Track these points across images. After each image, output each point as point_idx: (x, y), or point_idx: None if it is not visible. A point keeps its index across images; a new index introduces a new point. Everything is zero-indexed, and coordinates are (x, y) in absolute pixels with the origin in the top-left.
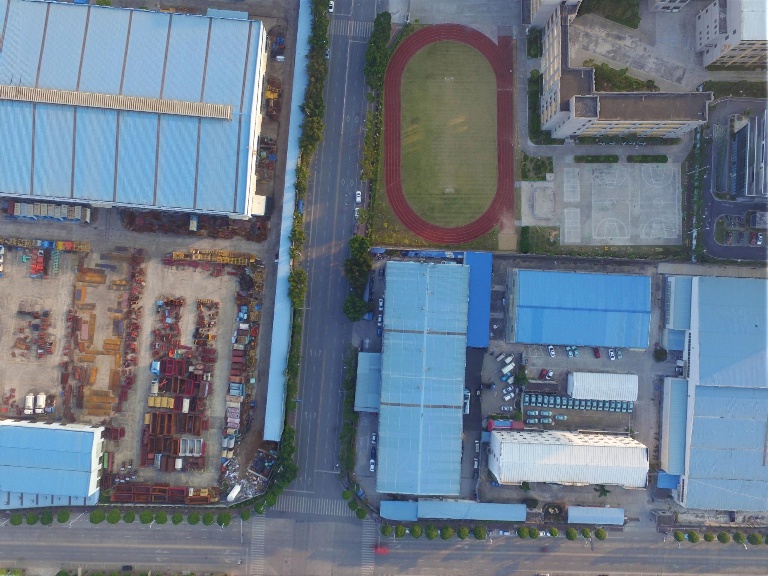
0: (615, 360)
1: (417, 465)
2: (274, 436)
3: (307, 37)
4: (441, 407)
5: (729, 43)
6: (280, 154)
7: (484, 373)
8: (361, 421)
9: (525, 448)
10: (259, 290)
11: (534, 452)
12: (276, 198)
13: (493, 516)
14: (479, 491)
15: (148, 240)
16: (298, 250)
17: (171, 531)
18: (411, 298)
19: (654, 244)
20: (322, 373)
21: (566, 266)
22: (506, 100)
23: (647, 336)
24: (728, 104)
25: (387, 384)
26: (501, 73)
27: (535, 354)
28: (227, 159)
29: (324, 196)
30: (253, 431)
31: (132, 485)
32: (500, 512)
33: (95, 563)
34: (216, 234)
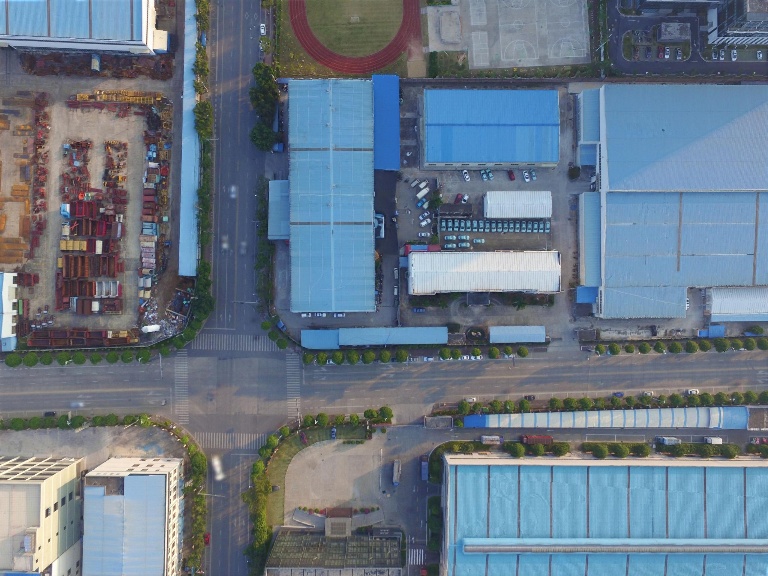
0: (530, 182)
1: (330, 282)
2: (189, 271)
3: None
4: (351, 224)
5: None
6: None
7: (400, 201)
8: (278, 255)
9: (437, 258)
10: (167, 128)
11: (446, 261)
12: (179, 35)
13: (415, 340)
14: (401, 319)
15: (51, 83)
16: None
17: (92, 376)
18: (315, 115)
19: (563, 64)
20: (236, 209)
21: None
22: None
23: (557, 149)
24: None
25: (296, 203)
26: None
27: (450, 180)
28: None
29: (228, 31)
30: (170, 271)
31: (49, 330)
32: (421, 335)
33: (17, 412)
34: (120, 74)
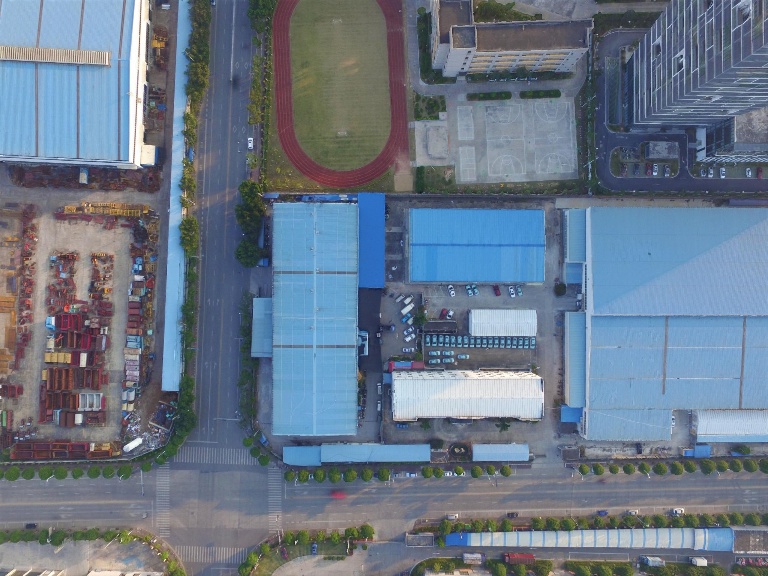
0: (516, 297)
1: (312, 406)
2: (172, 386)
3: None
4: (334, 347)
5: None
6: (170, 103)
7: (384, 315)
8: (262, 369)
9: (419, 384)
10: (153, 241)
11: (428, 387)
12: (167, 148)
13: (397, 457)
14: (384, 434)
15: (39, 195)
16: (190, 198)
17: (74, 487)
18: (299, 239)
19: (550, 179)
20: (221, 322)
21: (463, 205)
22: (396, 41)
23: (543, 270)
24: (619, 36)
25: (279, 326)
26: (390, 13)
27: (435, 294)
28: (108, 106)
29: (216, 144)
30: (153, 383)
31: (32, 442)
32: (404, 453)
33: None
34: (108, 186)
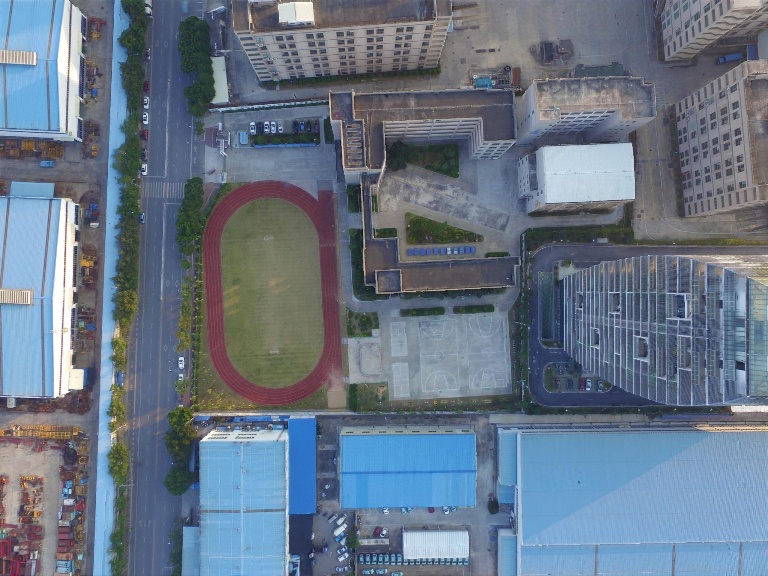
0: (449, 513)
1: None
2: None
3: (116, 207)
4: None
5: (539, 201)
6: (99, 323)
7: (318, 534)
8: None
9: None
10: (83, 463)
11: None
12: (97, 368)
13: None
14: None
15: None
16: (119, 423)
17: None
18: (226, 477)
19: (484, 395)
20: (153, 544)
21: (396, 421)
22: (329, 256)
23: (474, 494)
24: (552, 250)
25: (206, 565)
26: (323, 228)
27: (369, 512)
28: (32, 344)
29: (147, 363)
30: None
31: None
32: None
33: None
34: (36, 409)
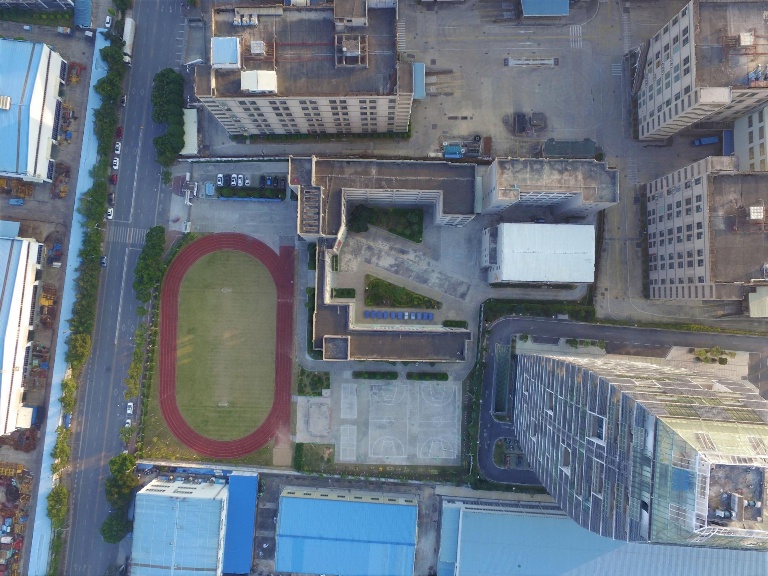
0: None
1: None
2: None
3: (78, 250)
4: None
5: (497, 275)
6: (53, 362)
7: None
8: None
9: None
10: (25, 502)
11: None
12: (47, 407)
13: None
14: None
15: None
16: (62, 465)
17: None
18: (159, 532)
19: (431, 464)
20: None
21: (340, 484)
22: (286, 311)
23: (411, 568)
24: (511, 323)
25: None
26: (282, 284)
27: (305, 575)
28: None
29: (96, 406)
30: None
31: None
32: None
33: None
34: None
